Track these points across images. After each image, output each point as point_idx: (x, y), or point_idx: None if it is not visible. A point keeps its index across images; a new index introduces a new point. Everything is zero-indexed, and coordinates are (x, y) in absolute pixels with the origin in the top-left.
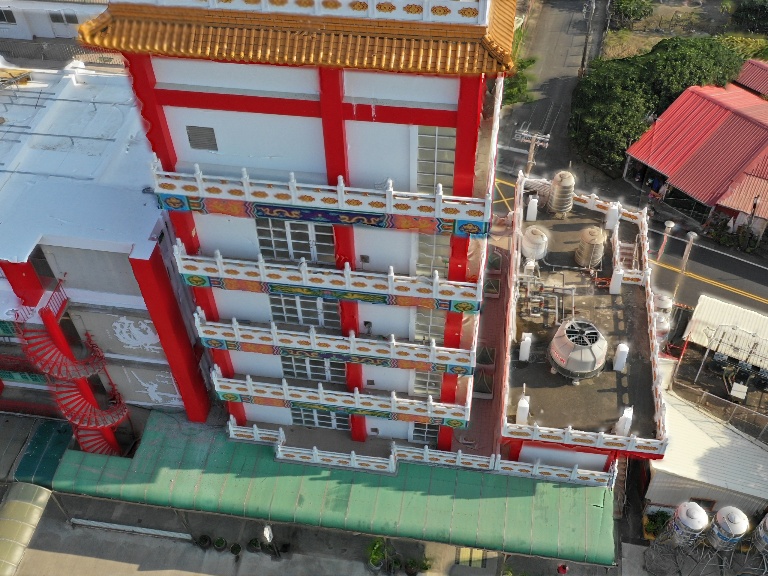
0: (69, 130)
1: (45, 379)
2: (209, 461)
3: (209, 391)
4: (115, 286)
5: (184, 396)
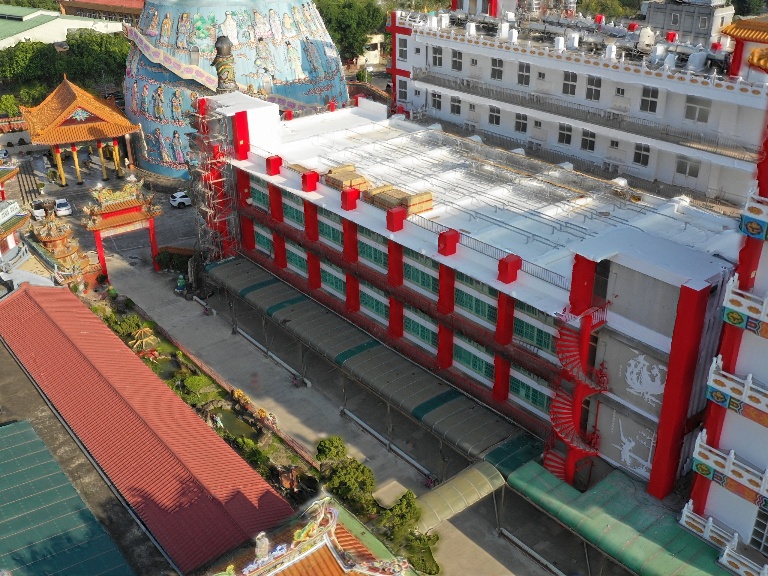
0: (657, 234)
1: (542, 404)
2: (650, 530)
3: (676, 479)
4: (652, 321)
5: (656, 459)
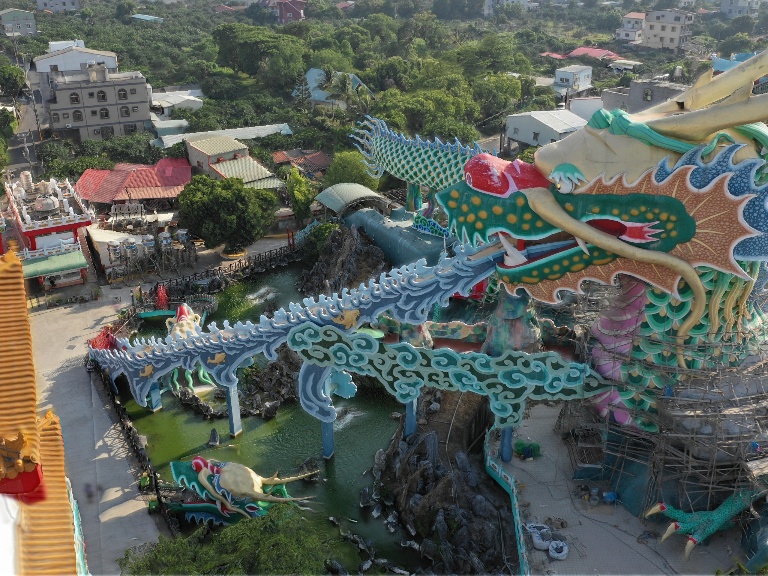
0: None
1: None
2: None
3: None
4: None
5: None
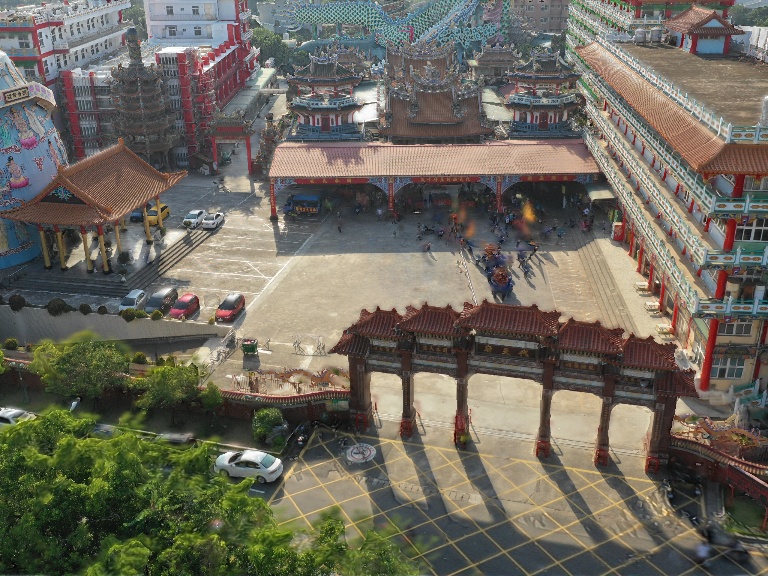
0: None
1: None
2: None
3: None
4: None
5: None
